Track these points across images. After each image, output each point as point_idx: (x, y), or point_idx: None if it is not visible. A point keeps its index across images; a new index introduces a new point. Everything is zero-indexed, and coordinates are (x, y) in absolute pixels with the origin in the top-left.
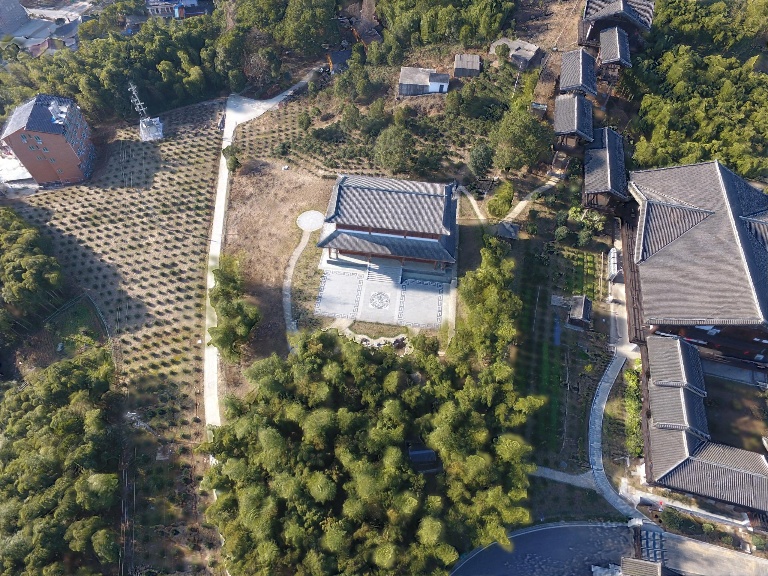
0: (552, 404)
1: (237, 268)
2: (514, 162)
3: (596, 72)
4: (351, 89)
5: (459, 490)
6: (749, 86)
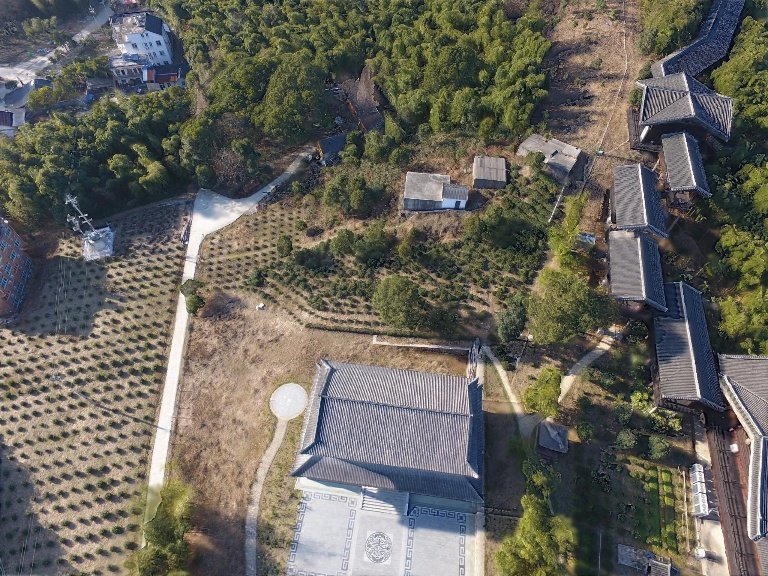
0: None
1: (180, 509)
2: (561, 341)
3: (660, 195)
4: (344, 200)
5: None
6: None
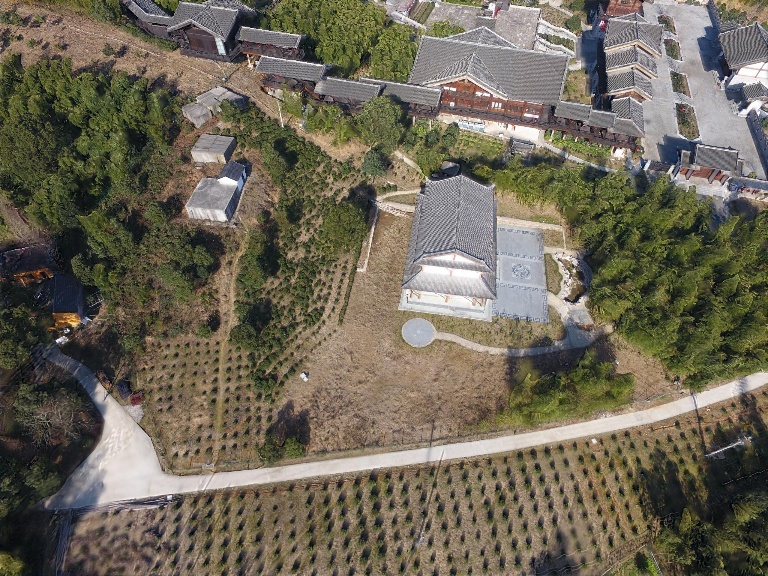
0: None
1: None
2: None
3: None
4: (195, 272)
5: (690, 217)
6: (318, 6)
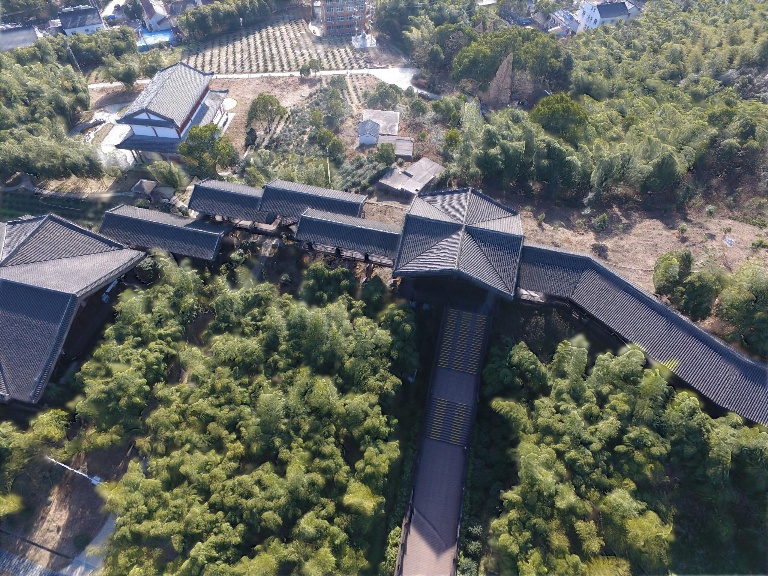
0: None
1: (165, 64)
2: None
3: None
4: None
5: None
6: (288, 467)
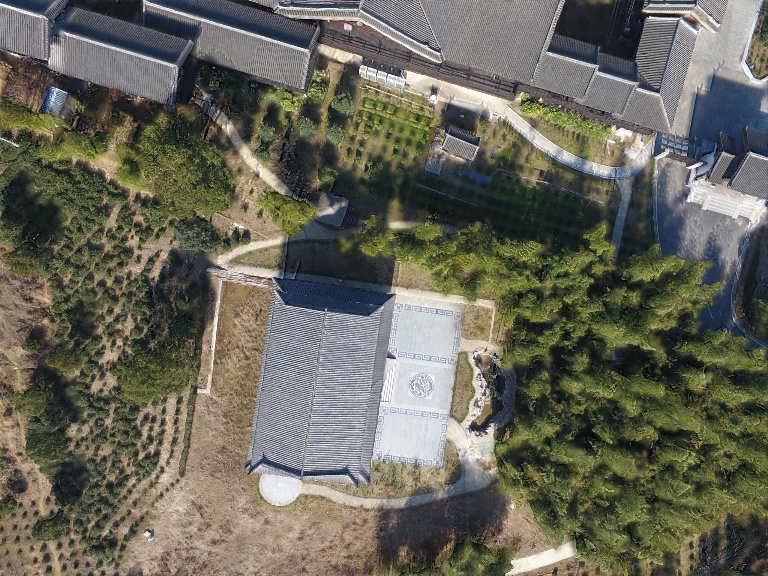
0: (558, 203)
1: None
2: None
3: None
4: None
5: (673, 321)
6: None
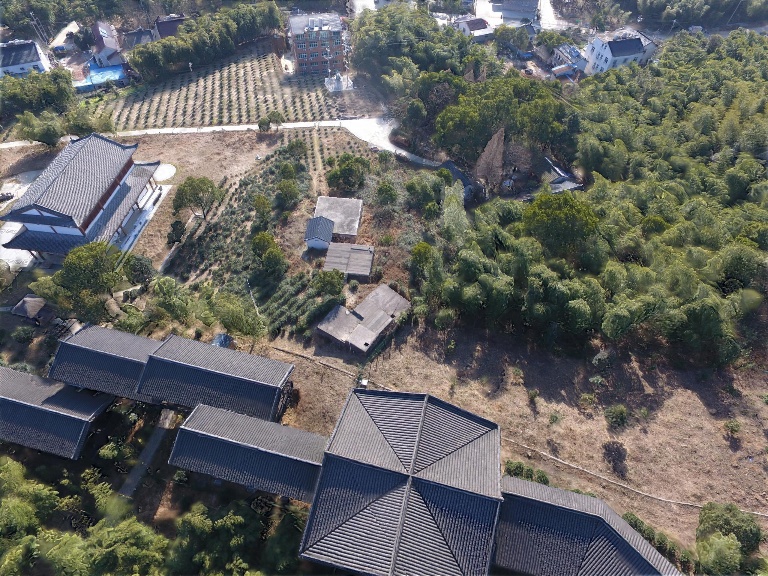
0: None
1: (93, 123)
2: None
3: None
4: None
5: None
6: None
